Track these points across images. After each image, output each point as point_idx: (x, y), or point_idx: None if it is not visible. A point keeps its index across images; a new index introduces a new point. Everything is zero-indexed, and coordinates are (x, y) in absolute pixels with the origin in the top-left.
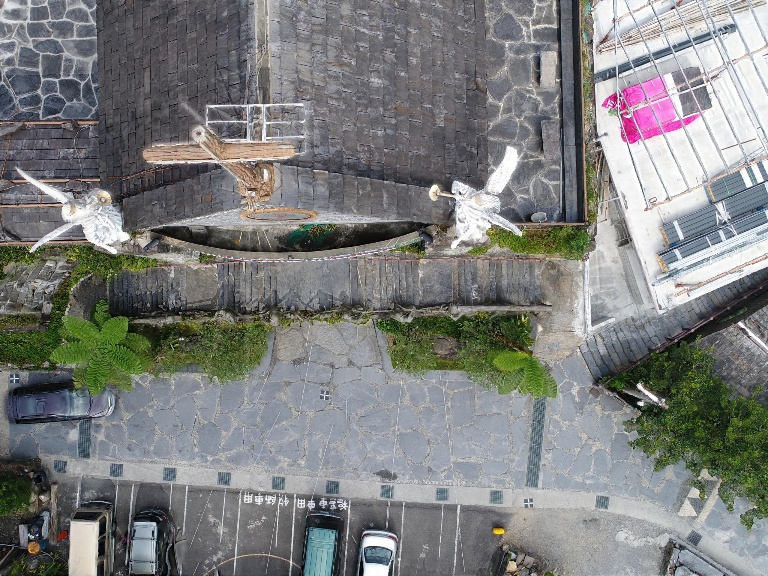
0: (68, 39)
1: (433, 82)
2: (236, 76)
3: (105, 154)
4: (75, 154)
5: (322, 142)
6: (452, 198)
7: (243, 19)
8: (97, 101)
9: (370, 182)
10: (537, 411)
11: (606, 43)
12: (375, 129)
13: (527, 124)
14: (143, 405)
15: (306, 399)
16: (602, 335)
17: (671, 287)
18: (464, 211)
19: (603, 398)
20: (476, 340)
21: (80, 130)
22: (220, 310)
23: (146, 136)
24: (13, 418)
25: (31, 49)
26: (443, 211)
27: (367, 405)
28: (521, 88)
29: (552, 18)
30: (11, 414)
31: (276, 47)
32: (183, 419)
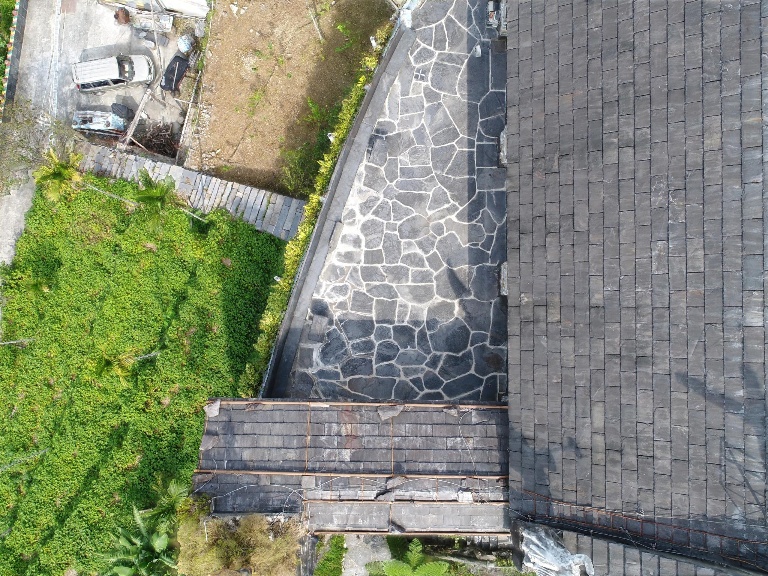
0: (403, 284)
1: None
2: (758, 464)
3: (519, 464)
4: (463, 444)
5: None
6: None
7: None
8: (432, 349)
9: None
10: None
11: None
12: None
13: None
14: None
15: None
16: None
17: None
18: None
19: None
20: None
21: (463, 415)
22: None
23: (595, 472)
24: None
25: (364, 293)
26: None
27: None
28: None
29: None
30: None
31: None
32: None
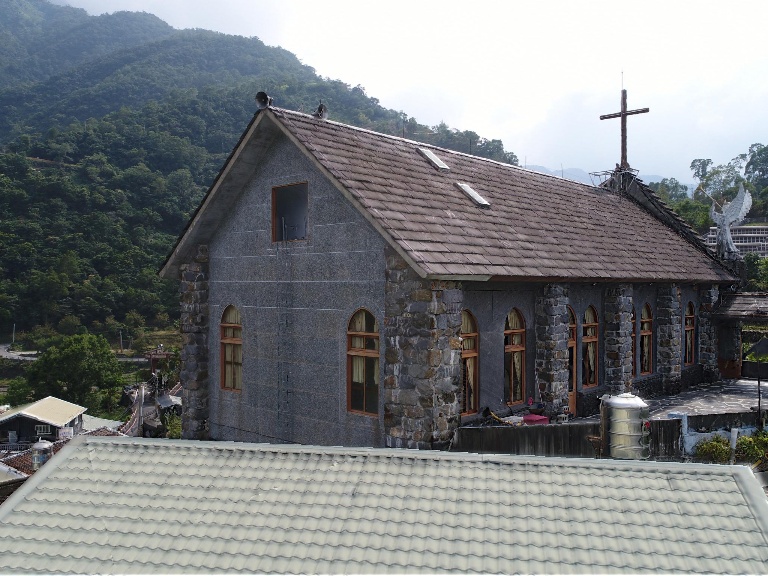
0: None
1: None
2: None
3: None
4: (760, 305)
5: None
6: None
7: None
8: None
9: None
10: None
11: None
12: None
13: None
14: None
15: None
16: None
17: None
18: None
19: None
20: None
21: (753, 313)
22: None
23: None
24: None
25: None
26: None
27: None
28: None
29: None
30: None
31: None
32: None
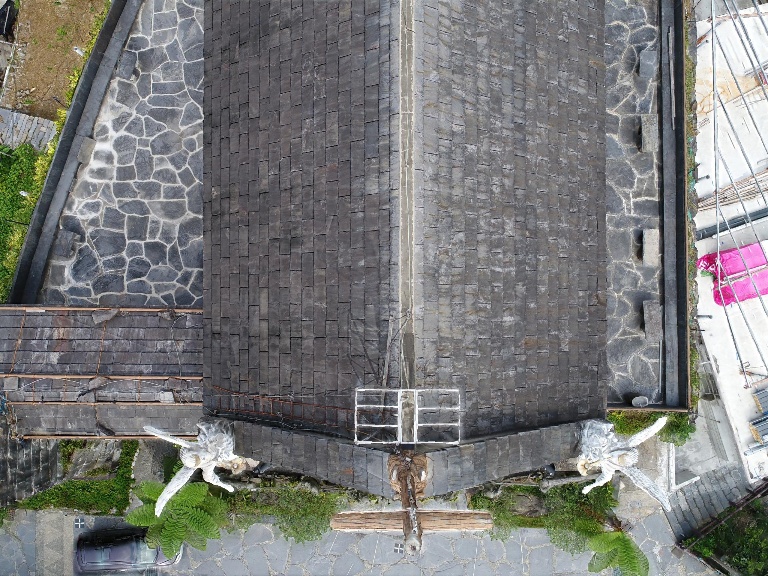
0: (155, 200)
1: (559, 306)
2: (374, 333)
3: (210, 360)
4: (173, 346)
5: (460, 398)
6: (578, 429)
7: (384, 276)
8: (183, 265)
9: (508, 440)
10: (617, 570)
11: (700, 203)
12: (507, 370)
13: (626, 299)
14: (212, 554)
15: (379, 552)
16: (683, 489)
17: (763, 455)
18: (602, 464)
19: (686, 558)
20: (563, 508)
21: (177, 319)
22: (305, 482)
23: (261, 359)
24: (78, 564)
25: (116, 210)
26: (569, 445)
27: (442, 560)
28: (620, 262)
29: (653, 190)
30: (76, 560)
31: (420, 309)
32: (252, 570)
